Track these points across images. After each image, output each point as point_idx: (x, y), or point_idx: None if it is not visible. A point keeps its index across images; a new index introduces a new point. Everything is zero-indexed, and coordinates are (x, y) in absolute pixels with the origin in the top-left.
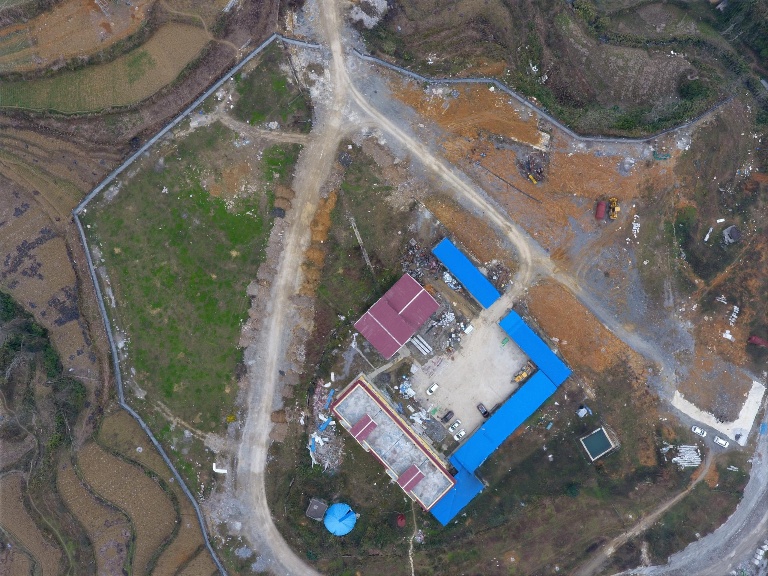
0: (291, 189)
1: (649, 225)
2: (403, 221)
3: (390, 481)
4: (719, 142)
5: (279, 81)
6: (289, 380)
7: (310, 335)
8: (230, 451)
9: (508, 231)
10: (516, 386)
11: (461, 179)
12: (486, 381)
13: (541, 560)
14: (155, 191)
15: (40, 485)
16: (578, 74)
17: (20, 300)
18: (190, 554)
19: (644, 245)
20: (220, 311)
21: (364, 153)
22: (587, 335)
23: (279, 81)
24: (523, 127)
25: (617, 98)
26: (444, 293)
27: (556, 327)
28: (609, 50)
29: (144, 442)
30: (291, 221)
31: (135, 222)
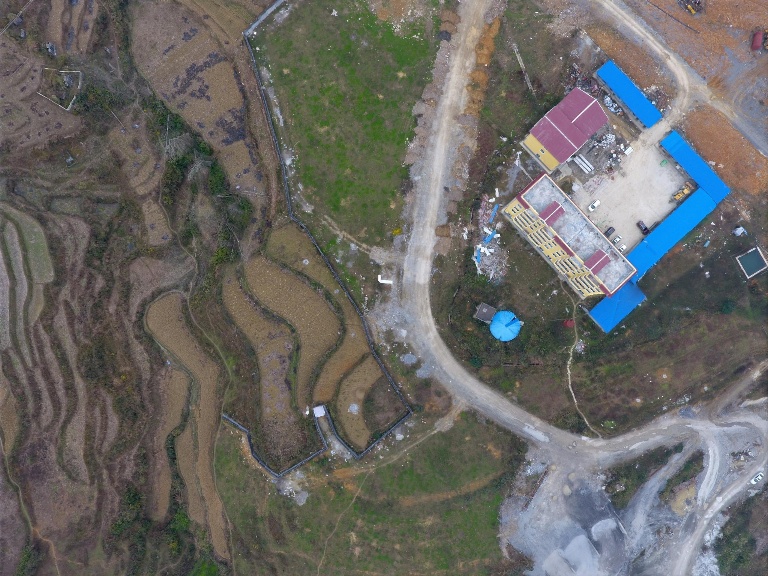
0: (457, 14)
1: None
2: (565, 47)
3: (552, 292)
4: None
5: None
6: (454, 195)
7: (473, 154)
8: (396, 263)
9: (666, 59)
10: (674, 206)
11: (621, 8)
12: (645, 200)
13: (692, 378)
14: (325, 14)
15: (205, 299)
16: None
17: (189, 120)
18: (354, 362)
19: None
20: (386, 130)
21: None
22: (742, 160)
23: None
24: None
25: None
26: None
27: (713, 151)
28: None
29: (310, 255)
30: (456, 44)
31: (304, 44)
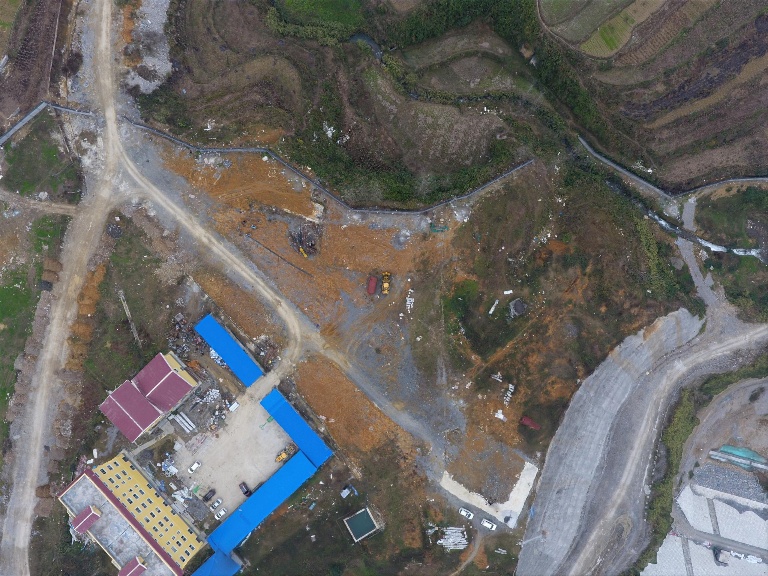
0: (59, 262)
1: (423, 300)
2: (171, 295)
3: None
4: (507, 211)
5: (50, 150)
6: (53, 456)
7: (77, 410)
8: None
9: (277, 306)
10: (280, 465)
11: (231, 252)
12: (250, 459)
13: None
14: None
15: None
16: (384, 133)
17: None
18: None
19: (418, 321)
20: None
21: (135, 224)
22: (355, 413)
23: (50, 150)
24: (296, 198)
25: (425, 157)
26: (210, 369)
27: (324, 405)
28: (418, 107)
29: None
30: (58, 294)
31: None
